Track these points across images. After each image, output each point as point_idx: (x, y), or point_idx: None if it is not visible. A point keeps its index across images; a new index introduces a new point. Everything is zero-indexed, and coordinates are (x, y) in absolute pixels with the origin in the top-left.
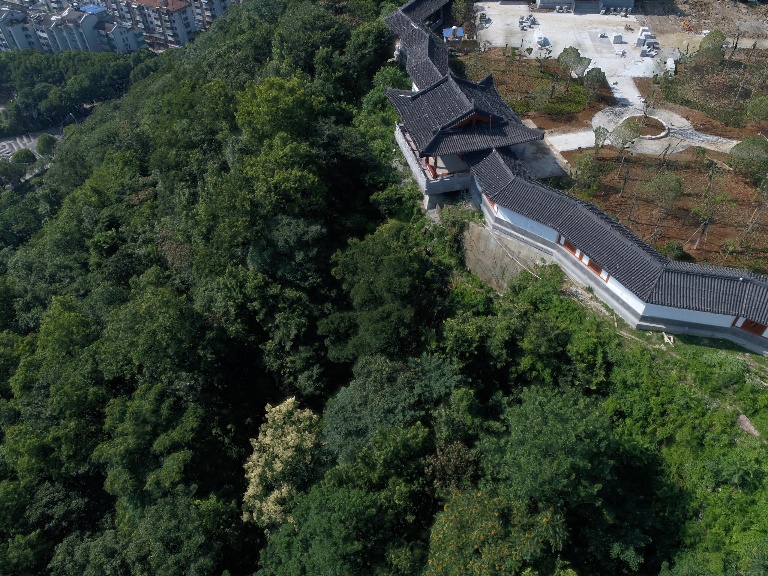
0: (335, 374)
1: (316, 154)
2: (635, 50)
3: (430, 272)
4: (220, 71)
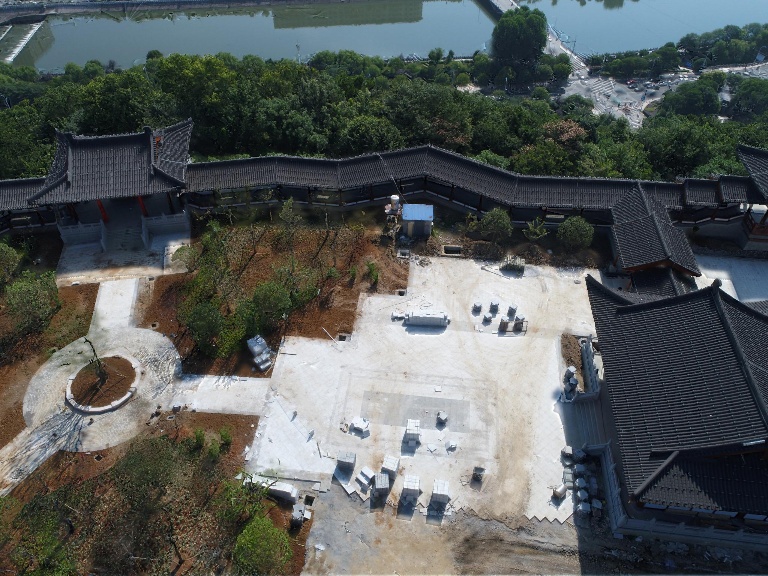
0: None
1: None
2: (370, 457)
3: None
4: None
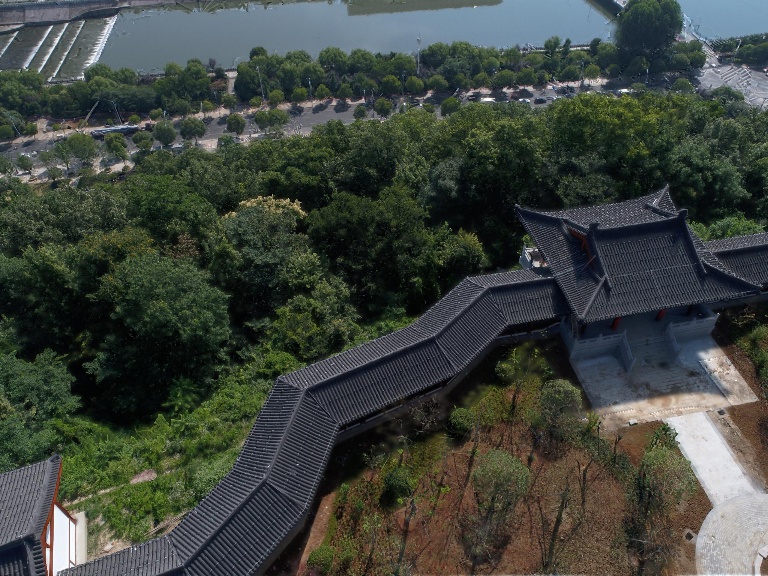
0: None
1: (549, 165)
2: None
3: (417, 279)
4: (765, 120)
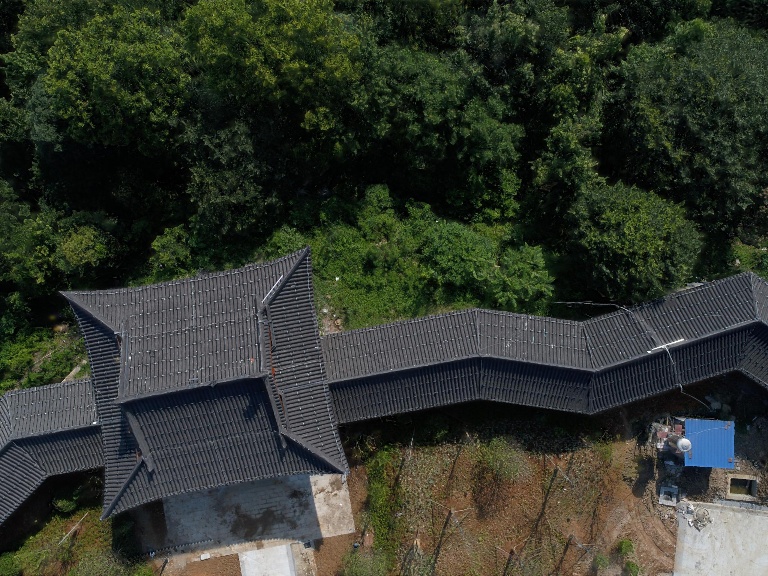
0: (10, 184)
1: (185, 125)
2: None
3: (14, 298)
4: None
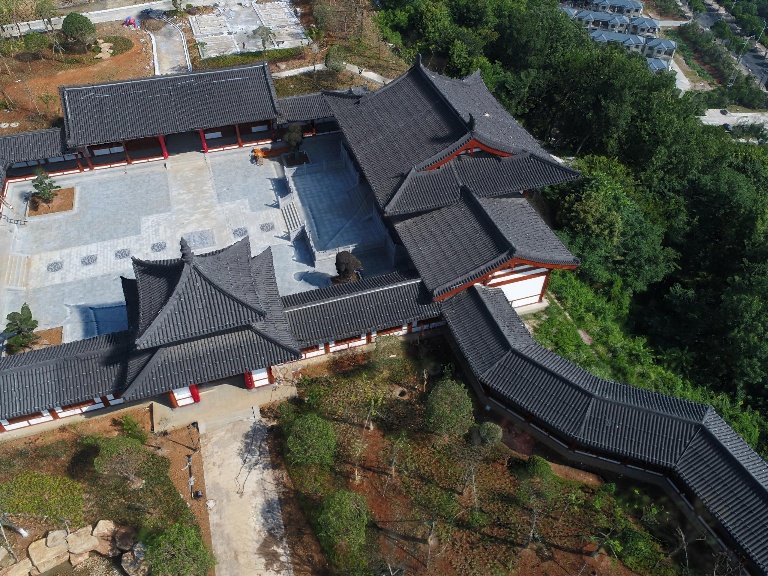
0: None
1: None
2: None
3: None
4: None
